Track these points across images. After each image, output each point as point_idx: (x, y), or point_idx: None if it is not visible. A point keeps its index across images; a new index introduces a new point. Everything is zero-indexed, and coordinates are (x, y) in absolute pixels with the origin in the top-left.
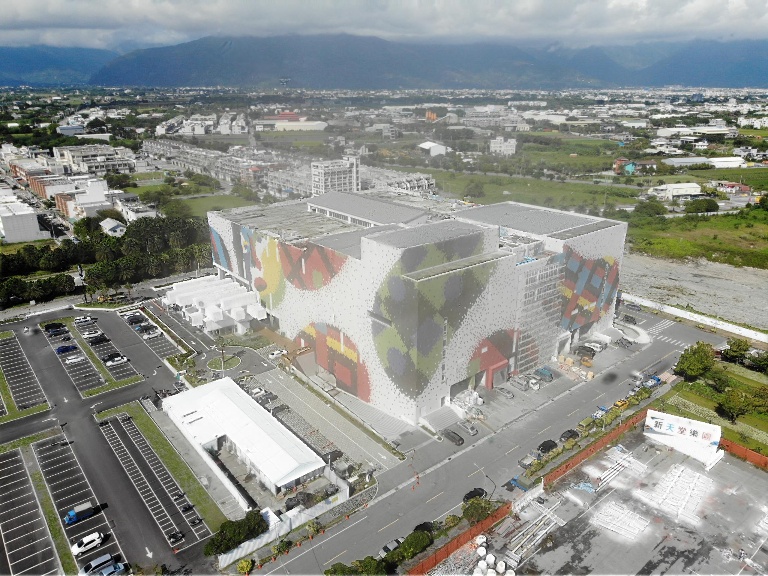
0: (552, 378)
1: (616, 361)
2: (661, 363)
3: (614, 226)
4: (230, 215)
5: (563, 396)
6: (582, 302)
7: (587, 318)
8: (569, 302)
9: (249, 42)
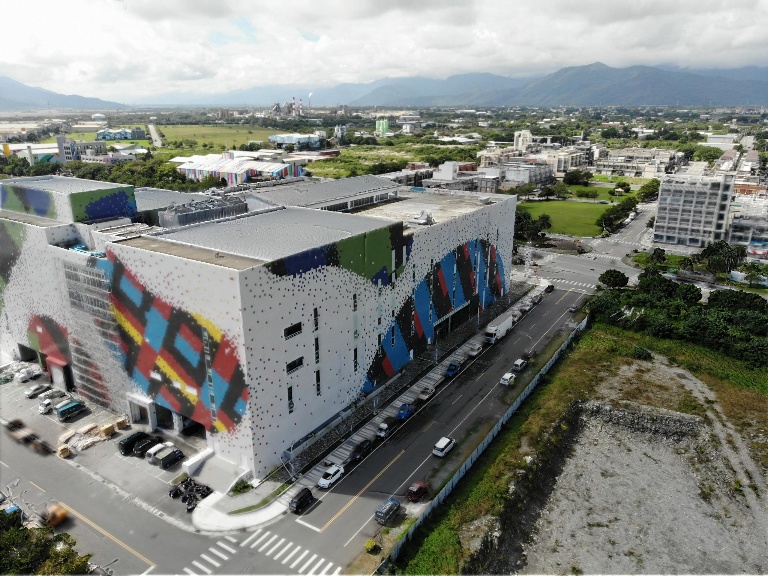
0: (69, 421)
1: (118, 481)
2: (93, 534)
3: (204, 262)
4: (309, 182)
5: (19, 433)
6: (167, 369)
7: (186, 406)
8: (141, 350)
9: (105, 3)
